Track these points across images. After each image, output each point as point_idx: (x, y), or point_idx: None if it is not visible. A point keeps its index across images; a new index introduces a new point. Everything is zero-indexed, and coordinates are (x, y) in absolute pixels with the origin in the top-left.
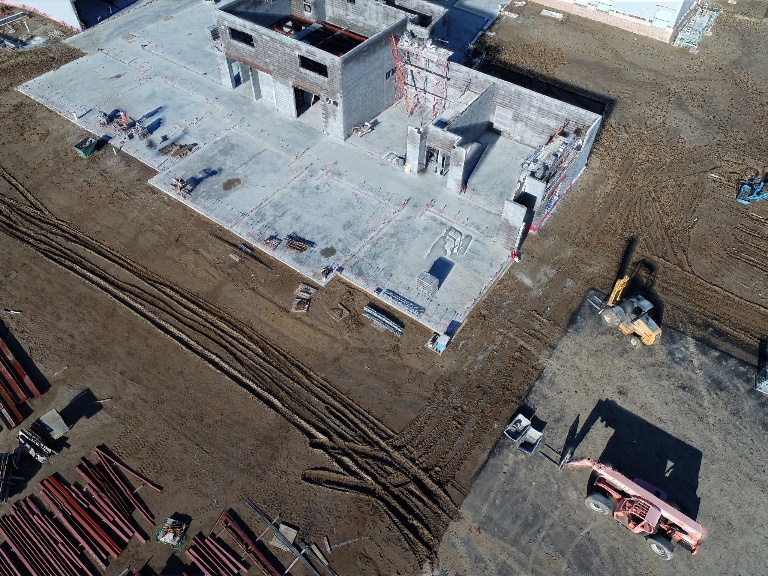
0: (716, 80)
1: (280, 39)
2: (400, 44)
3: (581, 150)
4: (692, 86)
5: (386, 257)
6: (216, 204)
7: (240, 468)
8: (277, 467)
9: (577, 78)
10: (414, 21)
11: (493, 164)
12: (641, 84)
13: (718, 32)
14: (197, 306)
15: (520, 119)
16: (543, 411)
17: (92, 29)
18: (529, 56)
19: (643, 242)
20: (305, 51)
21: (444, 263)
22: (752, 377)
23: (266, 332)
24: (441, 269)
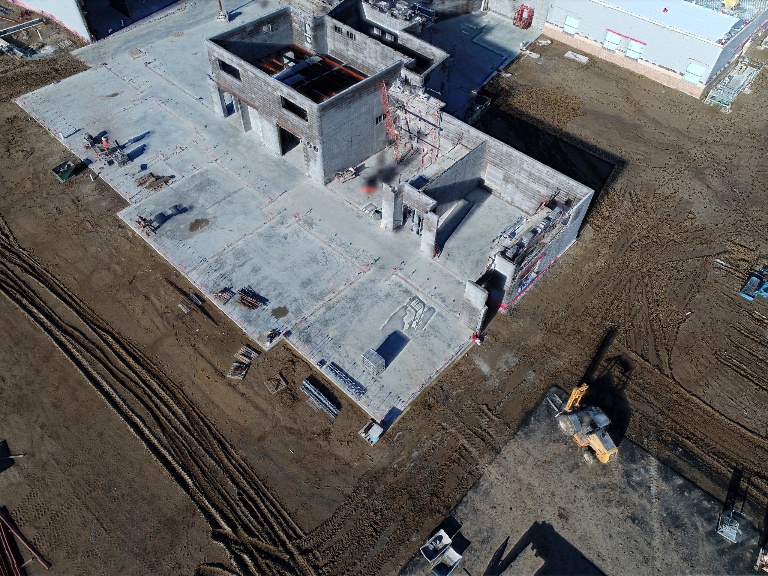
0: (745, 147)
1: (264, 78)
2: (392, 90)
3: (567, 226)
4: (716, 152)
5: (339, 324)
6: (178, 246)
7: (134, 553)
8: (172, 557)
9: (589, 133)
10: (411, 65)
11: (476, 226)
12: (659, 145)
13: (758, 90)
14: (133, 359)
15: (511, 180)
16: (470, 528)
17: (102, 41)
18: (542, 103)
19: (623, 335)
20: (287, 93)
21: (399, 338)
22: (715, 515)
23: (196, 397)
24: (394, 345)
